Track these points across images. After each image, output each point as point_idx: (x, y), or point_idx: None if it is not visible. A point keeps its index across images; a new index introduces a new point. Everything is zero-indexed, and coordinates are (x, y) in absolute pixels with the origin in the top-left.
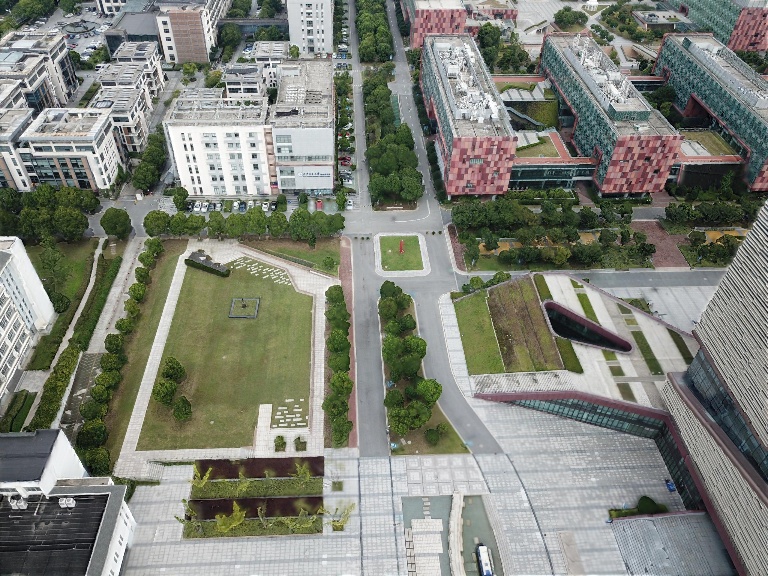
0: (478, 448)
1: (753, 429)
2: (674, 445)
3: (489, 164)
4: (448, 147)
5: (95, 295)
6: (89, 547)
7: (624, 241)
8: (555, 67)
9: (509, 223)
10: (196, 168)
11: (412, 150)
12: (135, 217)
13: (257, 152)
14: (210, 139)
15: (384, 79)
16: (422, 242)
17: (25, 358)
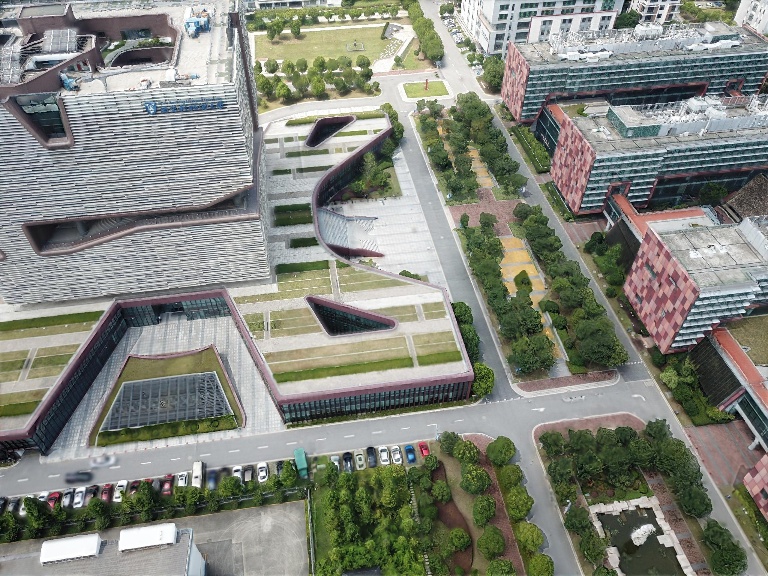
0: None
1: None
2: None
3: None
4: None
5: None
6: None
7: None
8: None
9: (466, 119)
10: None
11: None
12: (431, 8)
13: None
14: None
15: None
16: (442, 97)
17: (310, 6)
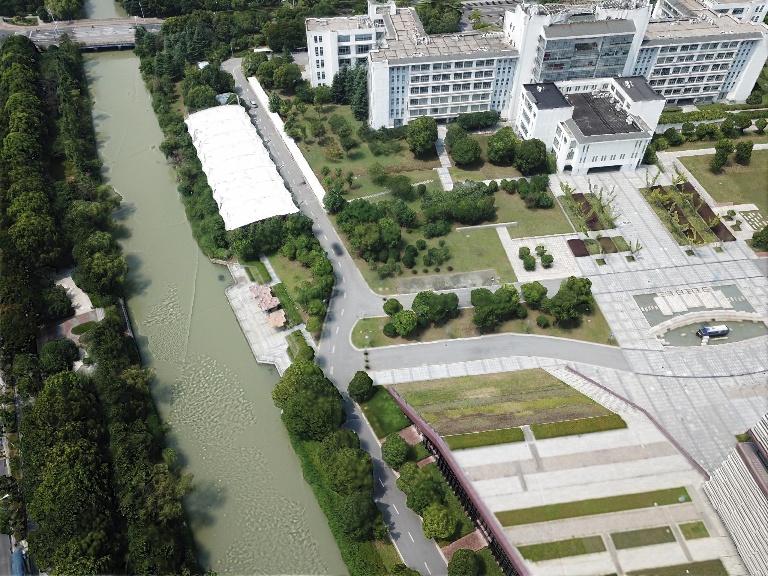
0: None
1: None
2: None
3: None
4: None
5: None
6: None
7: None
8: None
9: None
10: None
11: None
12: None
13: None
14: None
15: None
16: None
17: (703, 102)
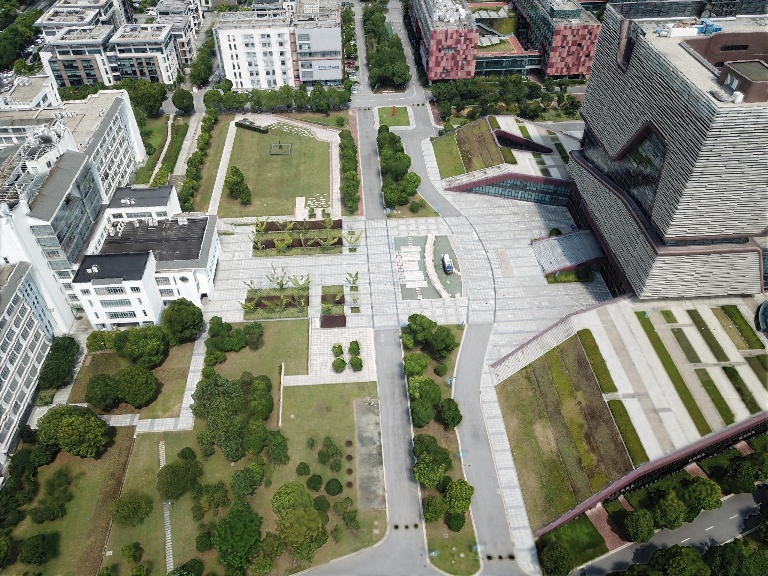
0: (446, 214)
1: (606, 151)
2: (576, 200)
3: (459, 52)
4: (428, 43)
5: (173, 145)
6: (200, 239)
7: (559, 101)
8: None
9: (474, 94)
10: (238, 65)
11: None
12: (194, 102)
13: (284, 50)
14: (249, 40)
15: (380, 8)
16: (409, 110)
17: (131, 178)
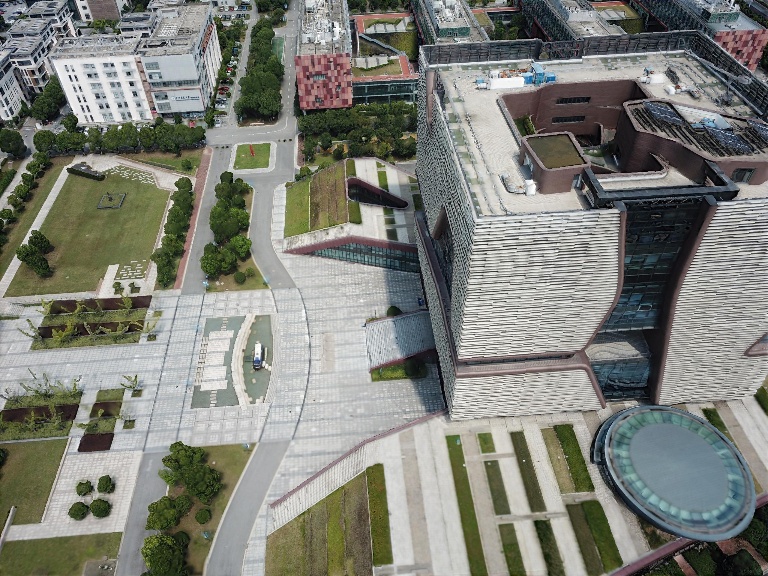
0: (276, 285)
1: (428, 225)
2: None
3: (330, 79)
4: None
5: None
6: None
7: None
8: (414, 1)
9: (345, 127)
10: (83, 97)
11: (281, 78)
12: None
13: (133, 80)
14: (90, 70)
15: (268, 22)
16: (273, 148)
17: None
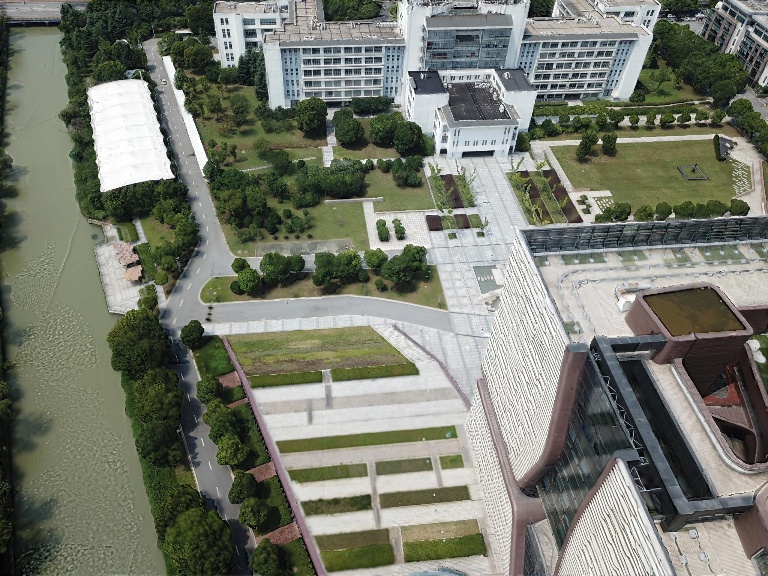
0: None
1: None
2: None
3: None
4: None
5: None
6: None
7: None
8: None
9: None
10: None
11: None
12: None
13: None
14: None
15: None
16: None
17: (589, 98)
